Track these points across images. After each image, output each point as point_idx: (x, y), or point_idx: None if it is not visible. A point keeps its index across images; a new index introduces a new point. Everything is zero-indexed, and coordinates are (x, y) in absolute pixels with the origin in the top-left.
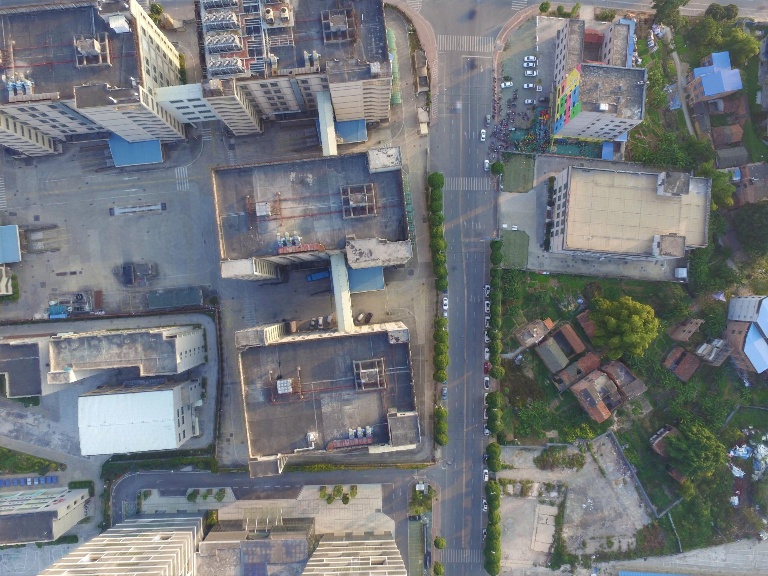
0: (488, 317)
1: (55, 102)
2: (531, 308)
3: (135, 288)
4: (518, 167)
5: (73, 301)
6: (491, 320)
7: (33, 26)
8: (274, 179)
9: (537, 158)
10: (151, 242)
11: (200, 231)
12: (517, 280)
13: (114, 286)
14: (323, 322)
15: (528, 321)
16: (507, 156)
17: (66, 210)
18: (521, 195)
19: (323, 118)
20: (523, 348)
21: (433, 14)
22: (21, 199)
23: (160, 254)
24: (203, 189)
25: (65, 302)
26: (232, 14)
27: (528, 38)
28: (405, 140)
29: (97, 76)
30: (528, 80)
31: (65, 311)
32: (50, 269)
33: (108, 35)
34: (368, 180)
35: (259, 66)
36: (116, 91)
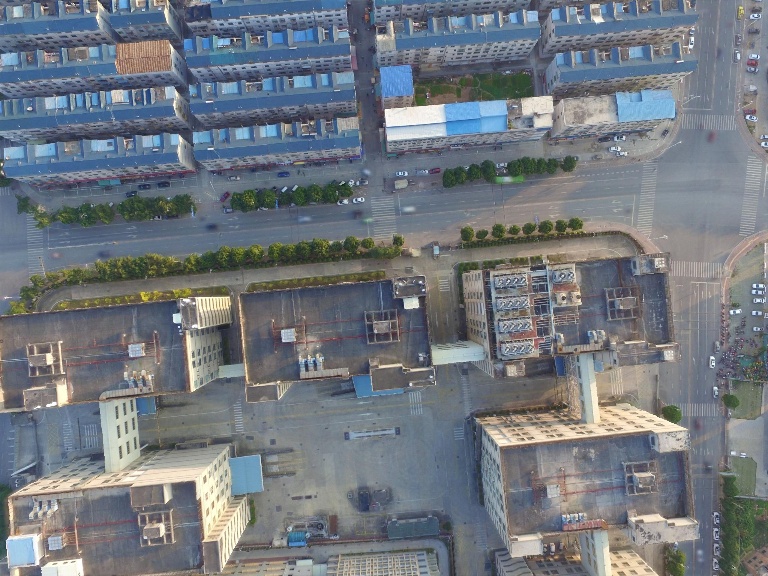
0: (717, 545)
1: (345, 378)
2: (758, 535)
3: (369, 512)
4: (746, 394)
5: (308, 525)
6: (727, 555)
7: (322, 300)
8: (557, 454)
9: (765, 385)
10: (385, 466)
11: (433, 456)
12: (749, 511)
13: (348, 510)
14: (555, 549)
15: (756, 548)
16: (735, 383)
17: (302, 434)
18: (749, 422)
19: (586, 374)
20: (751, 575)
21: (662, 240)
22: (258, 423)
23: (394, 478)
24: (436, 414)
25: (300, 526)
26: (528, 300)
27: (756, 264)
28: (635, 366)
29: (384, 350)
30: (756, 306)
31: (304, 539)
32: (286, 493)
33: (397, 311)
34: (649, 455)
35: (546, 345)
36: (411, 373)
